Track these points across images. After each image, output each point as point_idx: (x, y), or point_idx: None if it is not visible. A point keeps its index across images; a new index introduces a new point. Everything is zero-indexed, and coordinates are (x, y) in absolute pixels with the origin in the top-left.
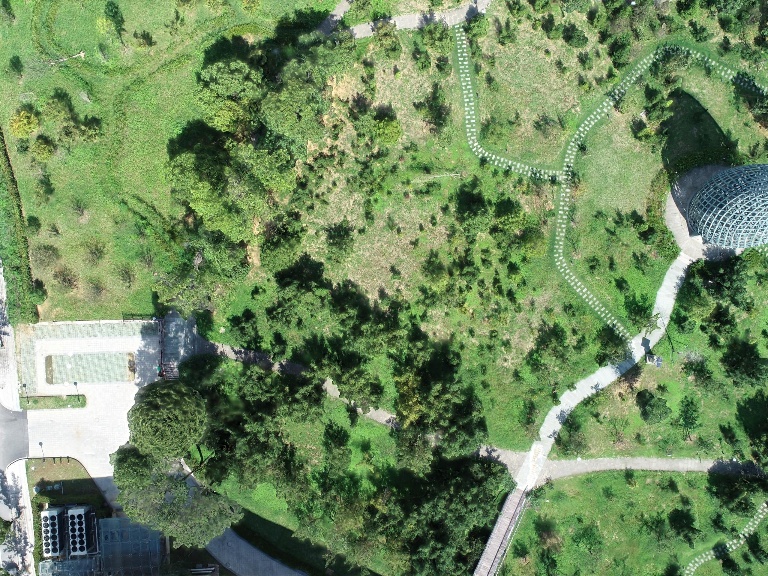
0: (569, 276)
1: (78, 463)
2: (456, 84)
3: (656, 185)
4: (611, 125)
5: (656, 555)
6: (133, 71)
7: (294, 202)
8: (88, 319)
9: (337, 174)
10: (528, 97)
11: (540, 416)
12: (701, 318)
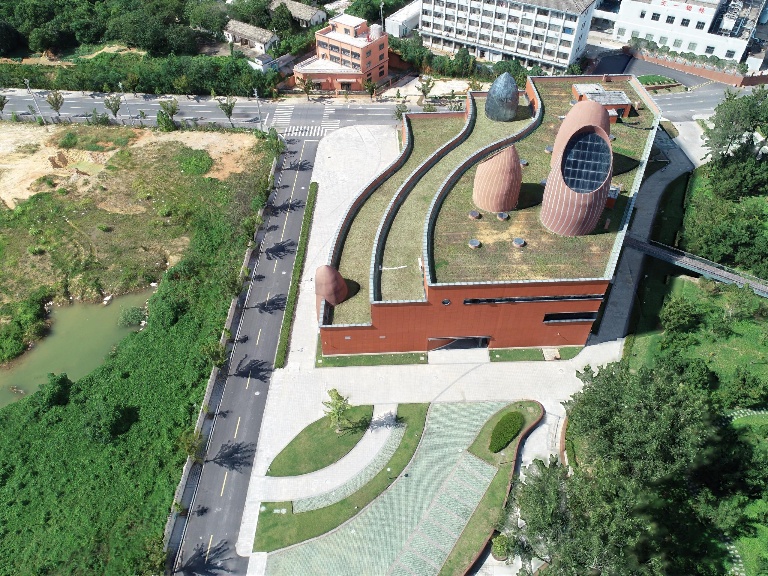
0: None
1: (678, 135)
2: None
3: None
4: None
5: None
6: None
7: None
8: (762, 135)
9: None
10: None
11: None
12: None
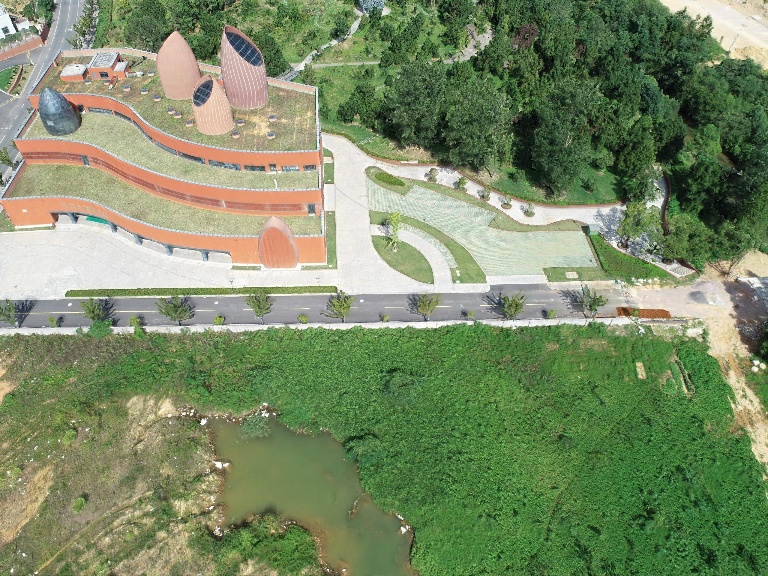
0: (319, 26)
1: None
2: (281, 0)
3: (351, 7)
4: (336, 3)
5: None
6: (166, 0)
7: (216, 14)
8: None
9: (234, 14)
10: (307, 1)
11: (306, 54)
12: (364, 19)
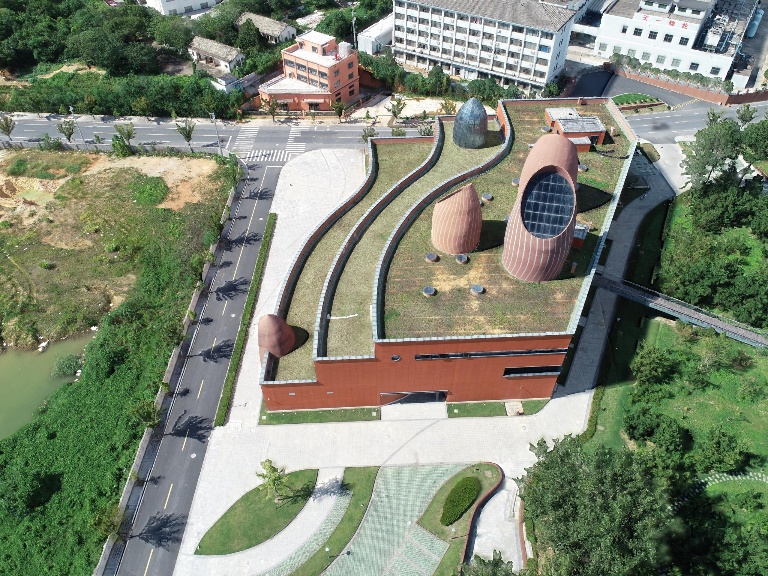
0: None
1: (659, 159)
2: None
3: None
4: None
5: (764, 445)
6: None
7: None
8: None
9: None
10: None
11: None
12: None
